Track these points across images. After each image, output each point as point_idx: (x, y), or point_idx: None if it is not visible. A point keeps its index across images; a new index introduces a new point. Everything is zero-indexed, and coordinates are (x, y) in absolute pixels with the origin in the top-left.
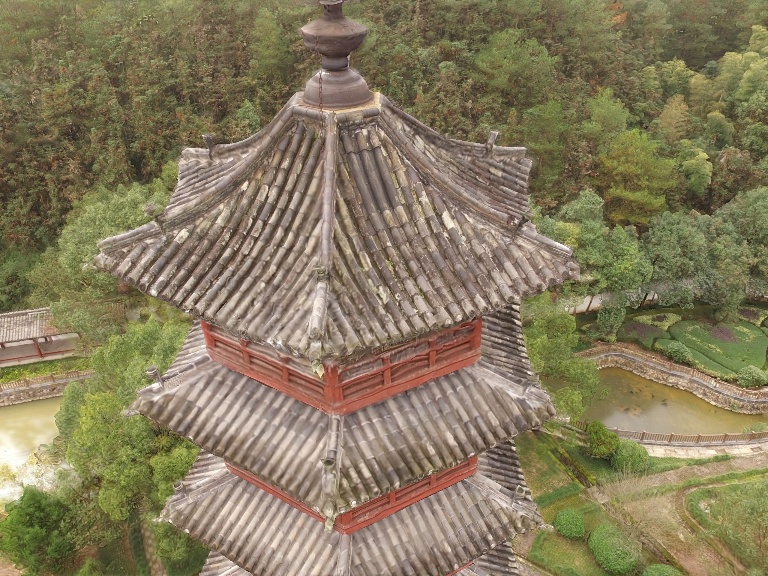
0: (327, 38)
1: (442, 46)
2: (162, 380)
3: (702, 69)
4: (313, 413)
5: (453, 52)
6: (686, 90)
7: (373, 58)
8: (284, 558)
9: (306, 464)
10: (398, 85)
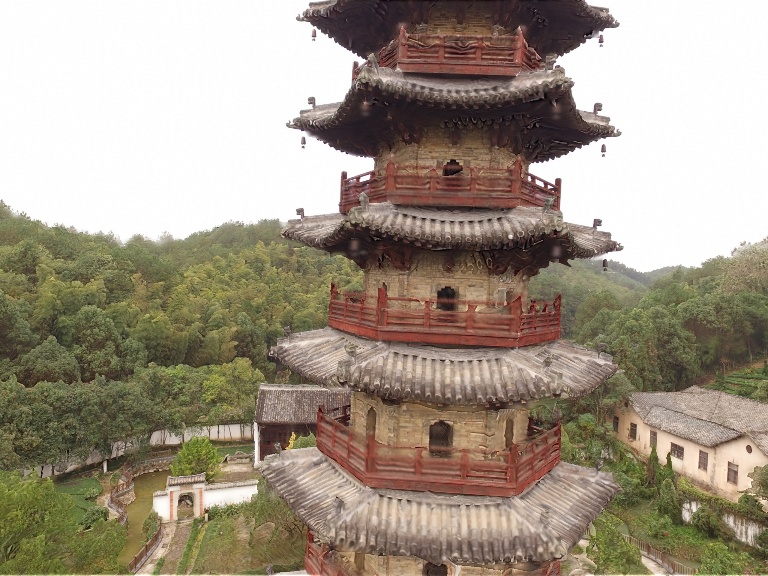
0: None
1: None
2: None
3: None
4: None
5: None
6: None
7: None
8: None
9: None
10: None
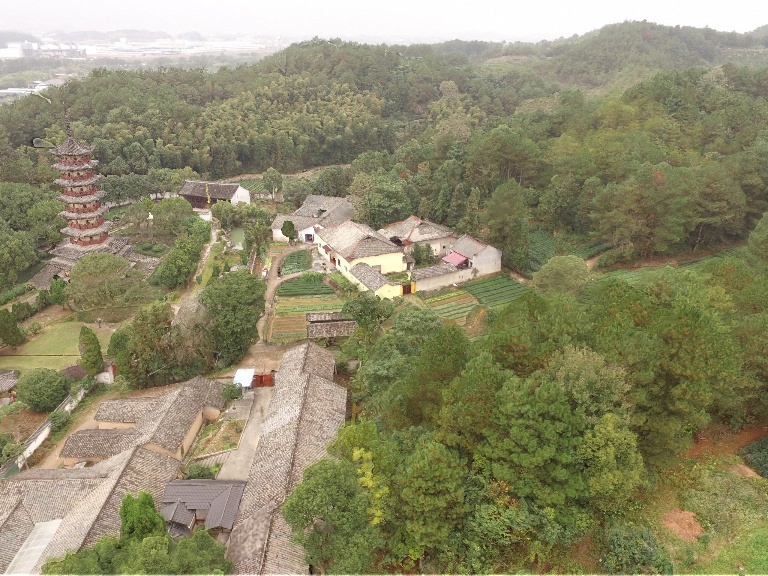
0: None
1: None
2: None
3: None
4: None
5: None
6: (36, 155)
7: None
8: None
9: None
10: None
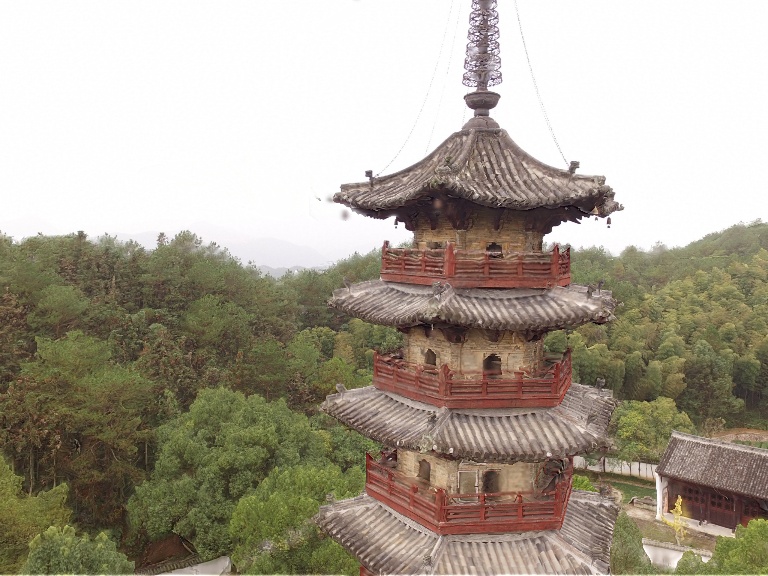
0: (492, 95)
1: (146, 313)
2: (440, 293)
3: (340, 330)
4: (536, 298)
5: (157, 317)
6: None
7: (83, 322)
8: (529, 441)
9: (566, 309)
10: (117, 343)
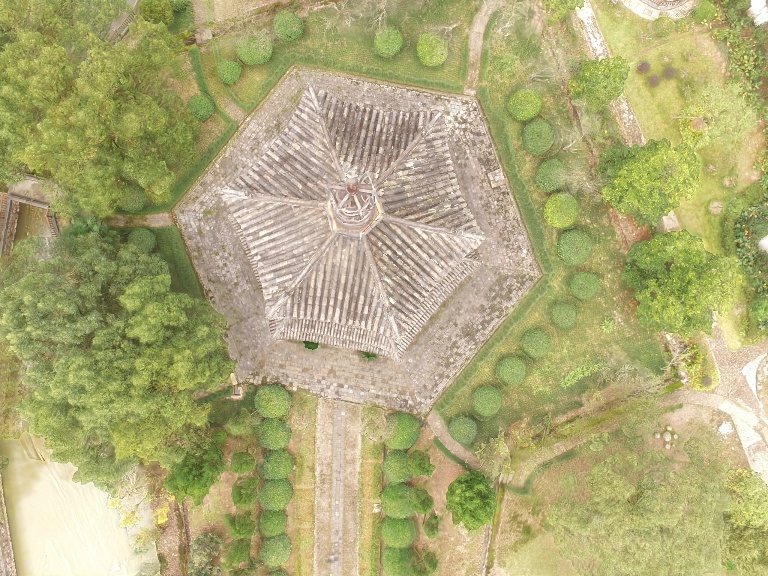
0: None
1: None
2: None
3: None
4: None
5: None
6: None
7: None
8: None
9: None
10: None
